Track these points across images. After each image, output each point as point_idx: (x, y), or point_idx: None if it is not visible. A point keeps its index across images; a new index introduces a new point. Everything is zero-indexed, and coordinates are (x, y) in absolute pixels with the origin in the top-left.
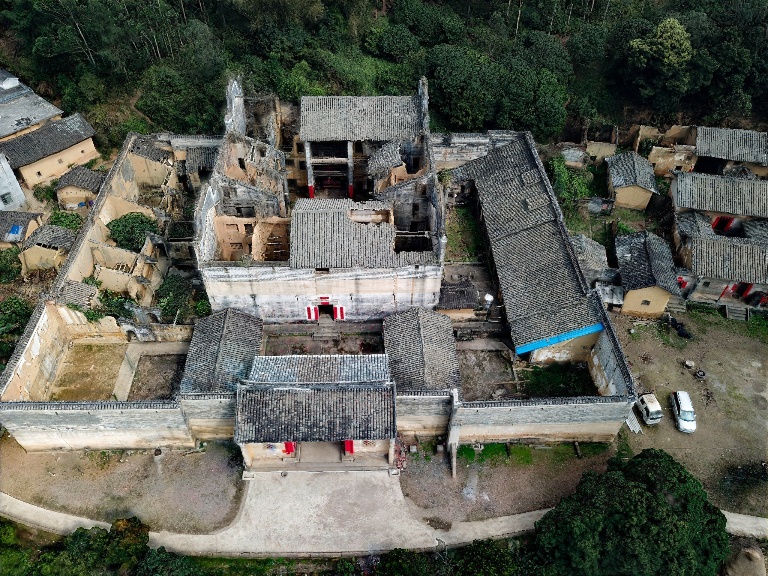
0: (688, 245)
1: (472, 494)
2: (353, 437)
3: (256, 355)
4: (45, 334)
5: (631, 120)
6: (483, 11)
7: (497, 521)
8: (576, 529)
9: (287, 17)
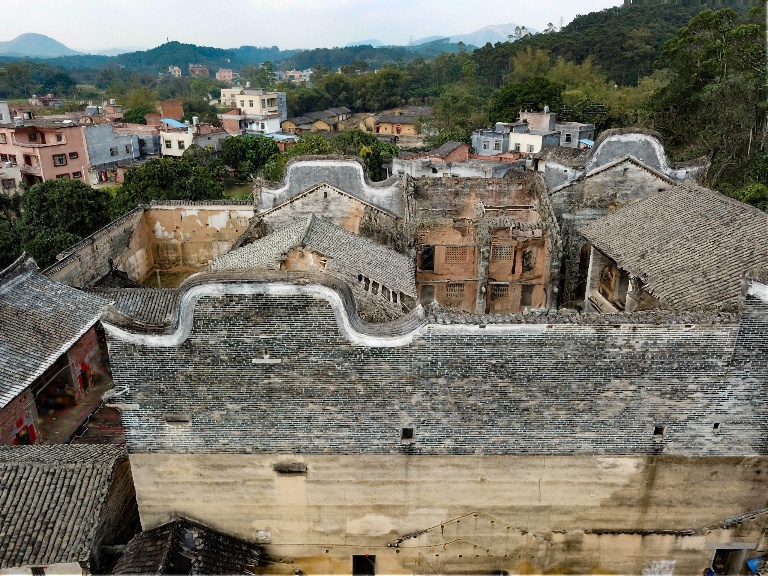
0: None
1: None
2: None
3: None
4: (241, 227)
5: None
6: None
7: None
8: None
9: None
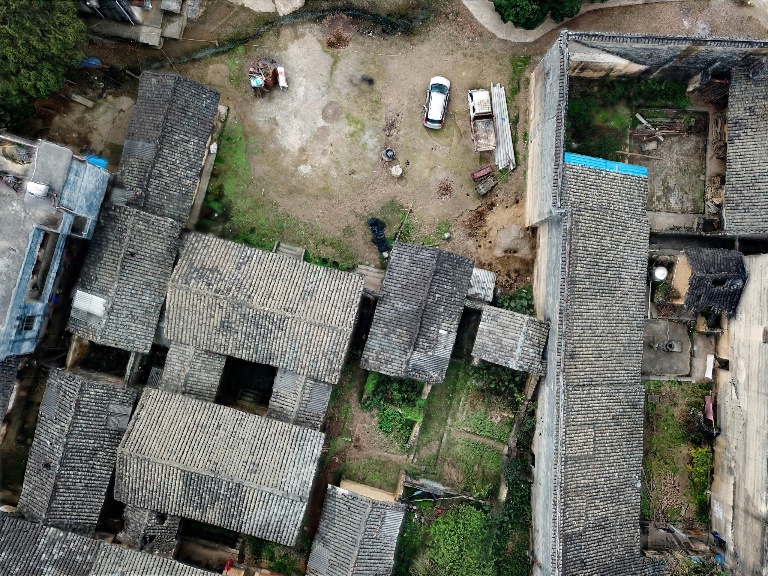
0: None
1: (700, 27)
2: None
3: None
4: None
5: None
6: None
7: None
8: None
9: None
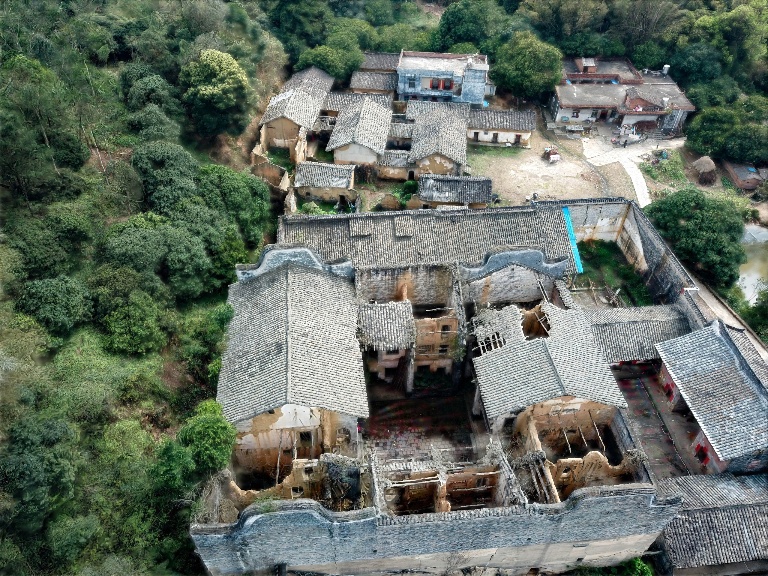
0: (424, 164)
1: None
2: (763, 361)
3: (693, 478)
4: None
5: (224, 160)
6: (13, 198)
7: (716, 311)
8: (735, 251)
9: (1, 431)
